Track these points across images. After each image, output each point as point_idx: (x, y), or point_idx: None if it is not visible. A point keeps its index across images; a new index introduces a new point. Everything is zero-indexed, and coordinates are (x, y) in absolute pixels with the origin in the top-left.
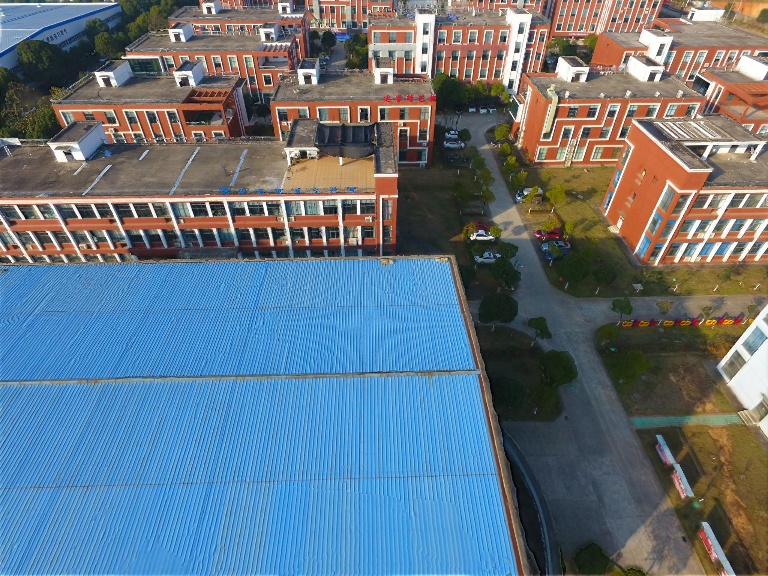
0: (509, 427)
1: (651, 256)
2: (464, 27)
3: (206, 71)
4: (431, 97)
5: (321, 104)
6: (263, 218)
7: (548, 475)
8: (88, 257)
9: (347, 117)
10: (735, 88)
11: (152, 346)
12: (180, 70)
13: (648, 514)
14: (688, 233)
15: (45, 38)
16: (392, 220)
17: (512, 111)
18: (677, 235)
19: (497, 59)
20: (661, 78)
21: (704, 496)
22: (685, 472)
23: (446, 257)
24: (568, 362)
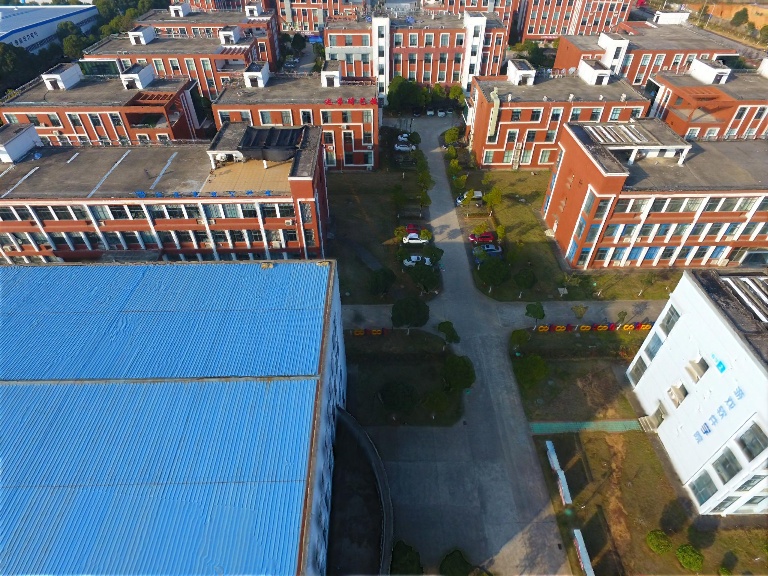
0: (405, 432)
1: (580, 260)
2: (420, 30)
3: (164, 74)
4: (372, 100)
5: (263, 107)
6: (183, 221)
7: (434, 480)
8: (14, 259)
9: (290, 120)
10: (682, 92)
11: (3, 349)
12: (127, 73)
13: (528, 521)
14: (614, 237)
15: (13, 41)
16: (312, 223)
17: (464, 114)
18: (603, 239)
19: (455, 62)
20: (609, 81)
21: (587, 503)
22: (573, 478)
23: (327, 261)
24: (464, 367)
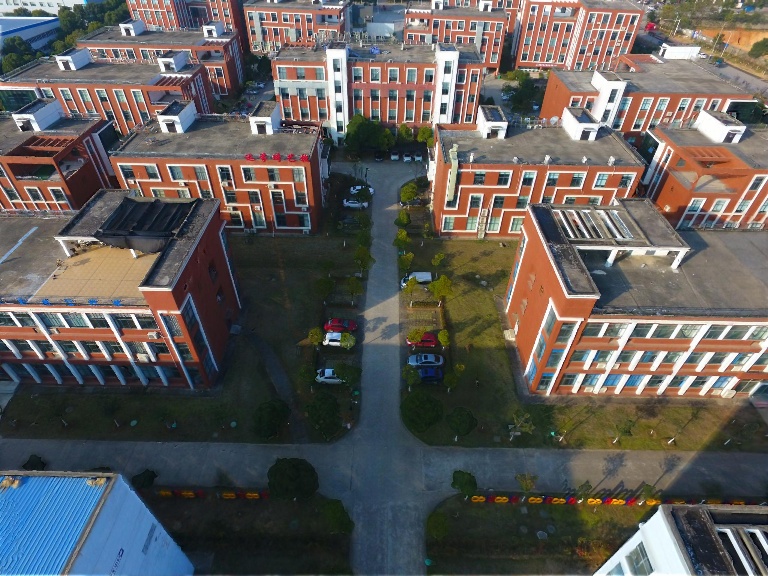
0: None
1: (541, 384)
2: (382, 64)
3: (91, 105)
4: (303, 157)
5: (171, 161)
6: (16, 329)
7: None
8: None
9: (206, 176)
10: (685, 153)
11: None
12: (23, 112)
13: None
14: (584, 362)
15: None
16: (184, 337)
17: (427, 165)
18: (569, 364)
19: (424, 100)
20: (597, 136)
21: None
22: None
23: (104, 477)
24: None
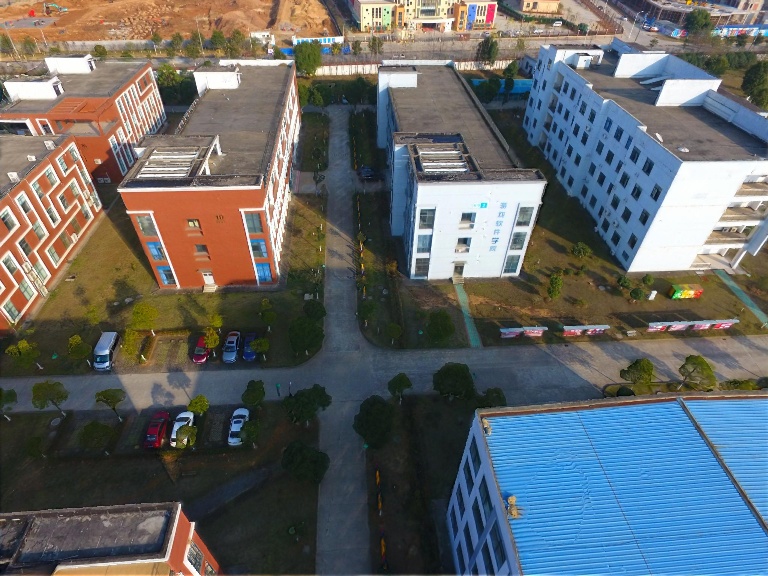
0: None
1: None
2: None
3: None
4: None
5: None
6: None
7: None
8: None
9: None
10: (60, 114)
11: None
12: None
13: (556, 360)
14: None
15: None
16: (204, 555)
17: None
18: None
19: None
20: None
21: (531, 324)
22: None
23: (482, 420)
24: None
